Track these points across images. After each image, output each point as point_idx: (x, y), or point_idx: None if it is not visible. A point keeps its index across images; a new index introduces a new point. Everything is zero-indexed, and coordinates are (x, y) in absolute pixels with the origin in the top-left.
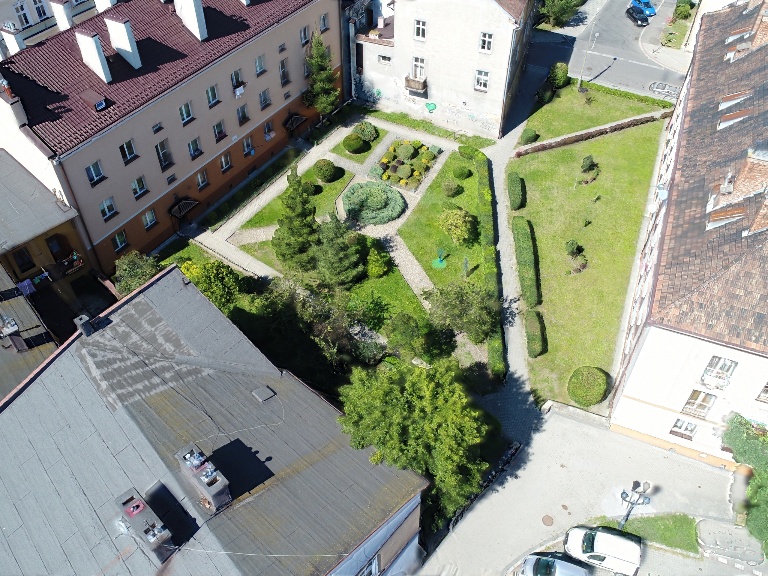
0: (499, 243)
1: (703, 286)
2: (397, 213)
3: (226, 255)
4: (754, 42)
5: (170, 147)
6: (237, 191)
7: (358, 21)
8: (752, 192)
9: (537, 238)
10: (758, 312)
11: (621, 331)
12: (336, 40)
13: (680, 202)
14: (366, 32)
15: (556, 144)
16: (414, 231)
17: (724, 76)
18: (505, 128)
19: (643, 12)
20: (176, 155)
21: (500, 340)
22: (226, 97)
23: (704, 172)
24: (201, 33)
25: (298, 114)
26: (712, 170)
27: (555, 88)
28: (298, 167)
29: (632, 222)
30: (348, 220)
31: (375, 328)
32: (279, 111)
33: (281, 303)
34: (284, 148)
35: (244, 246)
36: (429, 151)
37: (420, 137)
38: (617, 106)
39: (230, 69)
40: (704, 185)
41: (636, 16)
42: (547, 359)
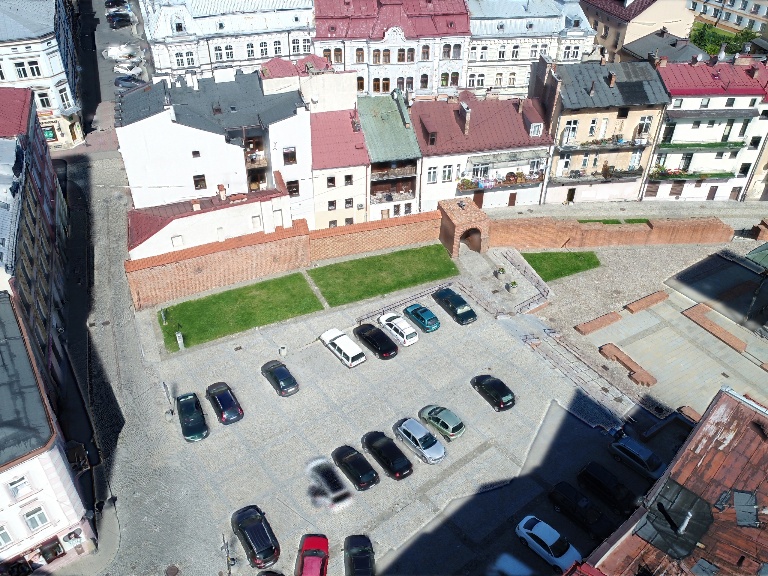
0: None
1: None
2: None
3: None
4: None
5: None
6: None
7: None
8: None
9: None
10: None
11: None
12: None
13: None
14: None
15: None
16: None
17: None
18: None
19: None
20: None
21: None
22: None
23: None
24: None
25: None
26: None
27: None
28: None
29: None
30: None
31: None
32: None
33: None
34: None
35: None
36: None
37: None
38: None
39: None
40: None
41: None
42: None
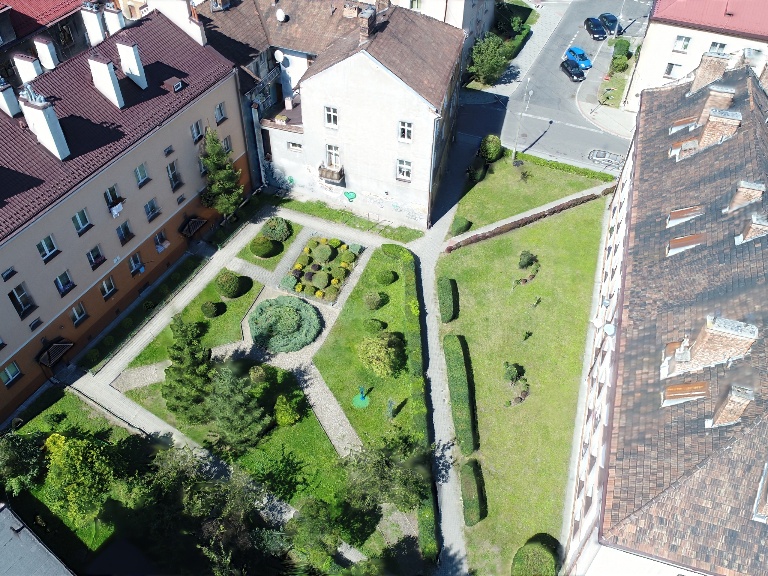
0: (429, 368)
1: (663, 496)
2: (312, 337)
3: (109, 406)
4: (701, 142)
5: (29, 290)
6: (125, 317)
7: (262, 104)
8: (713, 362)
9: (472, 359)
10: (729, 529)
11: (570, 480)
12: (237, 128)
13: (629, 357)
14: (272, 115)
15: (490, 234)
16: (332, 358)
17: (670, 179)
18: (434, 215)
19: (578, 66)
20: (39, 297)
21: (431, 509)
22: (100, 219)
23: (655, 316)
24: (61, 152)
25: (197, 216)
26: (664, 315)
27: (488, 162)
28: (198, 279)
29: (577, 330)
30: (256, 347)
31: (285, 498)
32: (172, 218)
33: (167, 485)
34: (183, 255)
35: (131, 392)
36: (349, 252)
37: (339, 232)
38: (555, 182)
39: (102, 187)
40: (656, 336)
41: (571, 71)
42: (487, 526)
